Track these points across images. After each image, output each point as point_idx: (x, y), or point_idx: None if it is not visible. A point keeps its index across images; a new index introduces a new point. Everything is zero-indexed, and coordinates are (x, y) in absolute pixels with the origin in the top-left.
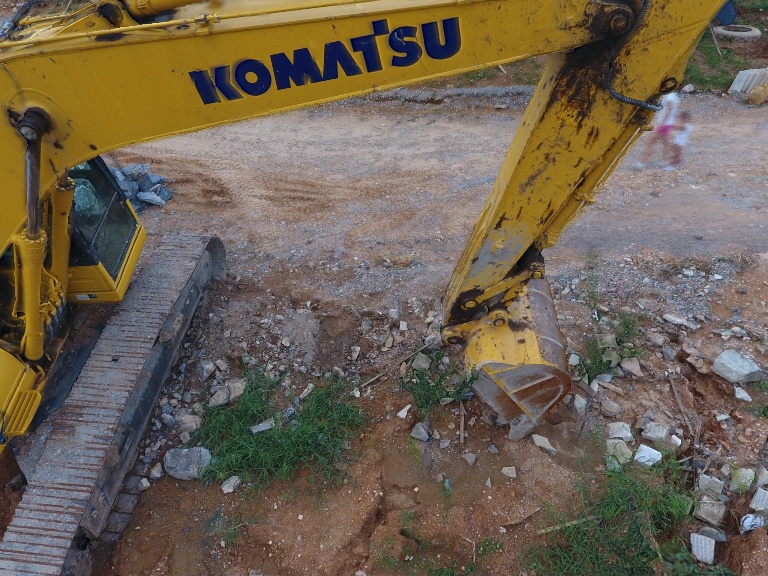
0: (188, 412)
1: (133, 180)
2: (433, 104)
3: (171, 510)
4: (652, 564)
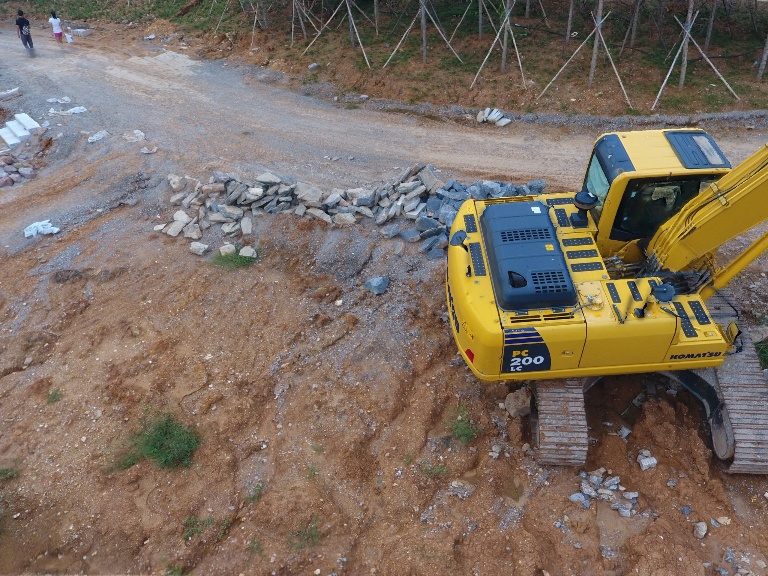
0: None
1: (540, 192)
2: (689, 126)
3: None
4: None
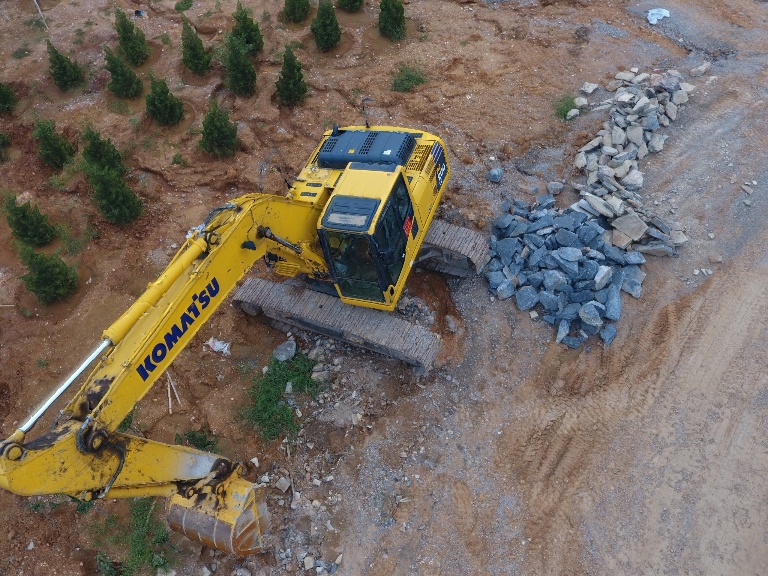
0: (319, 352)
1: None
2: None
3: (270, 345)
4: (116, 555)
